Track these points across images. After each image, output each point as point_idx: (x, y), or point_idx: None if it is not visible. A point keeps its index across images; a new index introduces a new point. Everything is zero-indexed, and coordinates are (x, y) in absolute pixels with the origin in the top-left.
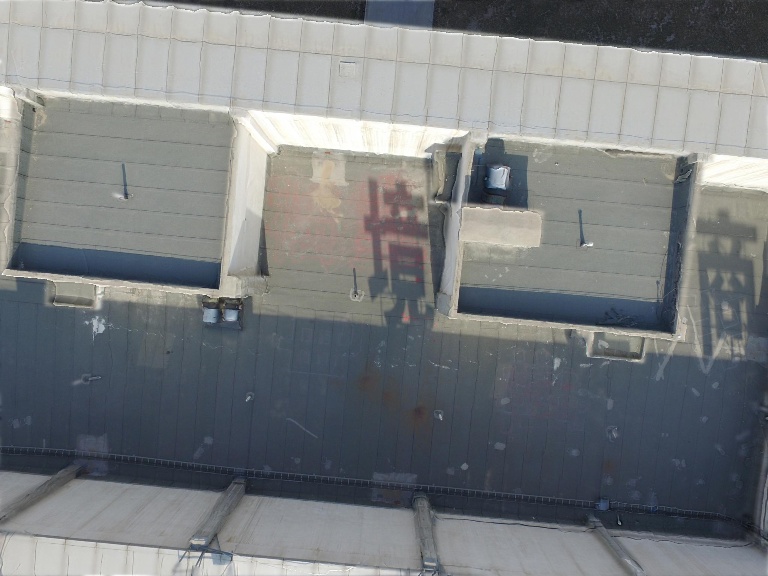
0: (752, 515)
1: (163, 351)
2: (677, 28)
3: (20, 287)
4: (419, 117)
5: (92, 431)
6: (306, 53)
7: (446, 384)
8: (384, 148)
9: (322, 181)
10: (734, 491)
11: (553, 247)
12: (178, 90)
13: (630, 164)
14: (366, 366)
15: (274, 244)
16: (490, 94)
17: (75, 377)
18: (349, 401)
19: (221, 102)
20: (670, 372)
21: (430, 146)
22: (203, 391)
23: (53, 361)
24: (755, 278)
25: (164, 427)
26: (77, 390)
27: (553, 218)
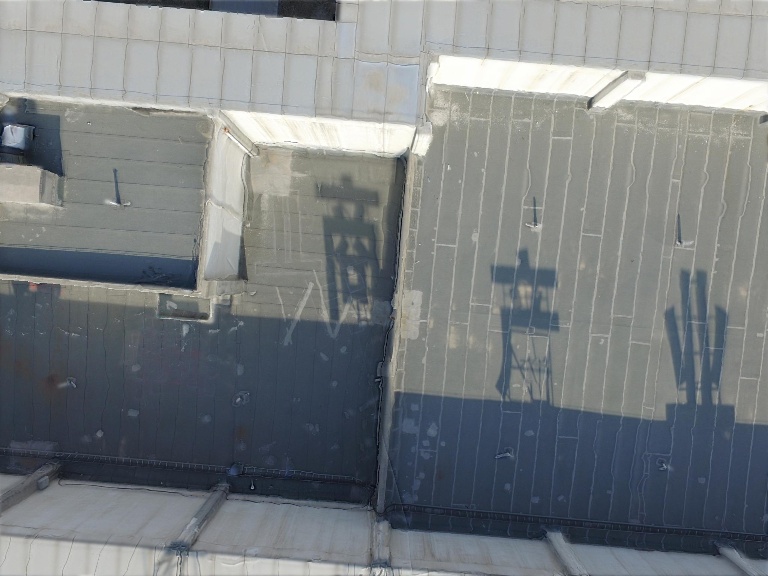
0: (371, 477)
1: None
2: None
3: None
4: None
5: None
6: None
7: (76, 351)
8: None
9: None
10: (360, 454)
11: (90, 206)
12: None
13: (162, 122)
14: None
15: None
16: None
17: None
18: None
19: None
20: (298, 337)
21: None
22: None
23: None
24: (377, 242)
25: None
26: None
27: (88, 177)
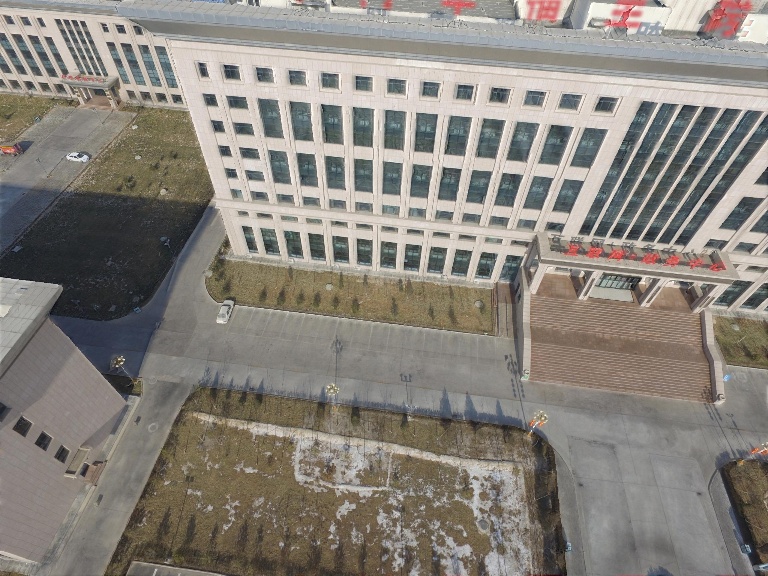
0: None
1: None
2: None
3: None
4: None
5: None
6: None
7: None
8: (683, 23)
9: None
10: None
11: None
12: None
13: None
14: None
15: None
16: None
17: None
18: None
19: None
20: None
21: (704, 15)
22: None
23: None
24: None
25: None
26: None
27: None
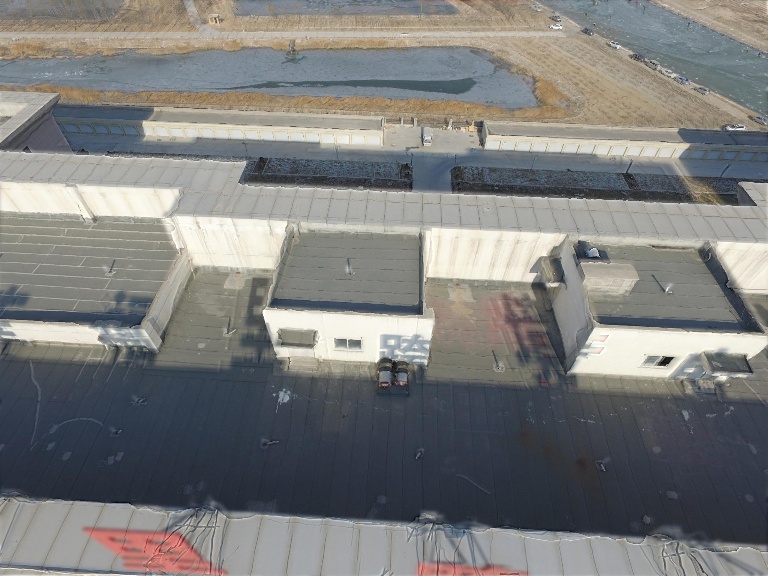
0: None
1: (339, 415)
2: None
3: (222, 370)
4: (535, 228)
5: (261, 497)
6: (463, 205)
7: (597, 436)
8: (501, 272)
9: (457, 300)
10: None
11: (646, 294)
12: (391, 219)
13: (670, 253)
14: (521, 423)
15: None
16: (573, 218)
17: (255, 442)
18: (512, 456)
19: (416, 224)
20: None
21: (535, 262)
22: (375, 450)
23: (237, 428)
24: None
25: (336, 487)
26: (255, 454)
27: None
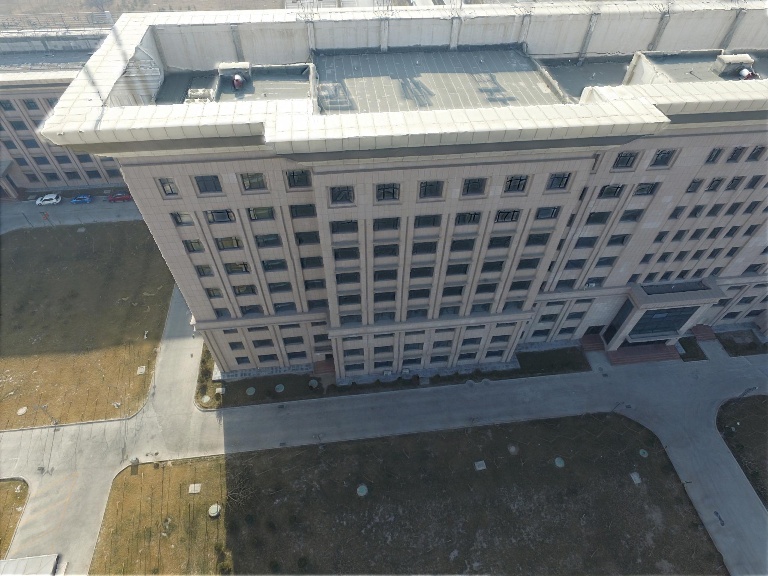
0: None
1: None
2: (450, 569)
3: None
4: None
5: None
6: None
7: None
8: None
9: None
10: None
11: None
12: None
13: None
14: None
15: None
16: None
17: None
18: None
19: None
20: None
21: None
22: (759, 72)
23: None
24: None
25: (762, 64)
26: None
27: None
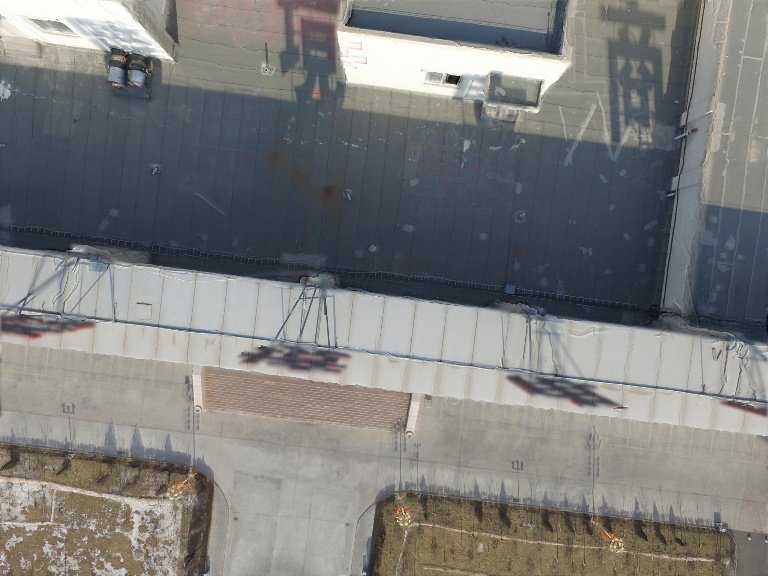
0: (653, 296)
1: (69, 119)
2: None
3: None
4: None
5: None
6: None
7: (355, 163)
8: None
9: None
10: (638, 276)
11: None
12: None
13: None
14: (275, 142)
15: (185, 13)
16: None
17: None
18: (257, 178)
19: None
20: (578, 158)
21: None
22: (109, 162)
23: None
24: (663, 65)
25: (68, 198)
26: None
27: None
